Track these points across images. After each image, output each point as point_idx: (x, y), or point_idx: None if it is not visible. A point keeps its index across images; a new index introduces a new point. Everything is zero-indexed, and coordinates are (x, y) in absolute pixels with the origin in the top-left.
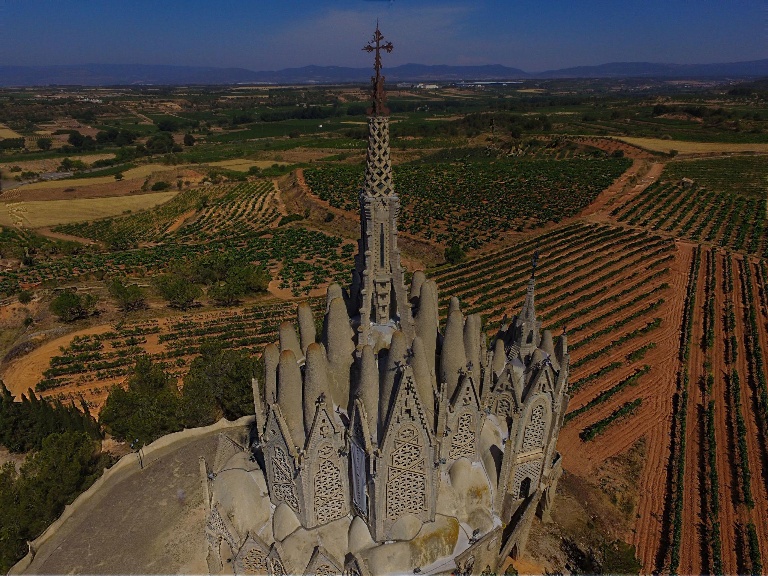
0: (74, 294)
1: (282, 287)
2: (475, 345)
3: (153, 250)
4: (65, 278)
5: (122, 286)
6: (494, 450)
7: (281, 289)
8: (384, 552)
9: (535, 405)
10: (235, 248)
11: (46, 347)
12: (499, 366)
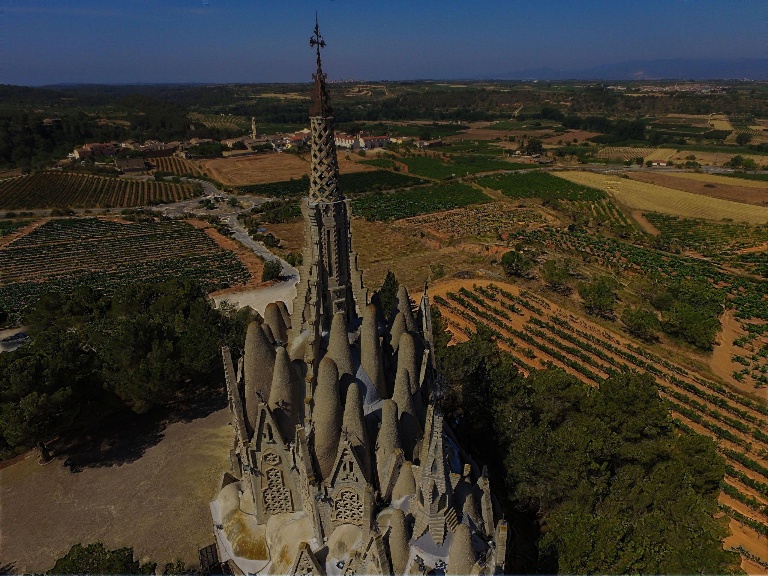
0: (521, 255)
1: (736, 359)
2: (348, 421)
3: (672, 258)
4: (574, 249)
5: (554, 265)
6: (322, 551)
7: (732, 360)
8: (228, 491)
9: (374, 574)
10: (760, 295)
11: (476, 281)
12: (395, 492)
